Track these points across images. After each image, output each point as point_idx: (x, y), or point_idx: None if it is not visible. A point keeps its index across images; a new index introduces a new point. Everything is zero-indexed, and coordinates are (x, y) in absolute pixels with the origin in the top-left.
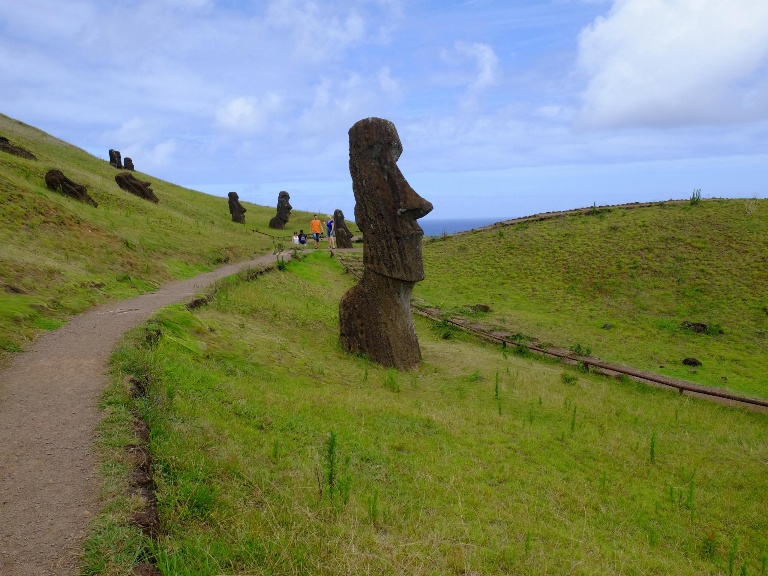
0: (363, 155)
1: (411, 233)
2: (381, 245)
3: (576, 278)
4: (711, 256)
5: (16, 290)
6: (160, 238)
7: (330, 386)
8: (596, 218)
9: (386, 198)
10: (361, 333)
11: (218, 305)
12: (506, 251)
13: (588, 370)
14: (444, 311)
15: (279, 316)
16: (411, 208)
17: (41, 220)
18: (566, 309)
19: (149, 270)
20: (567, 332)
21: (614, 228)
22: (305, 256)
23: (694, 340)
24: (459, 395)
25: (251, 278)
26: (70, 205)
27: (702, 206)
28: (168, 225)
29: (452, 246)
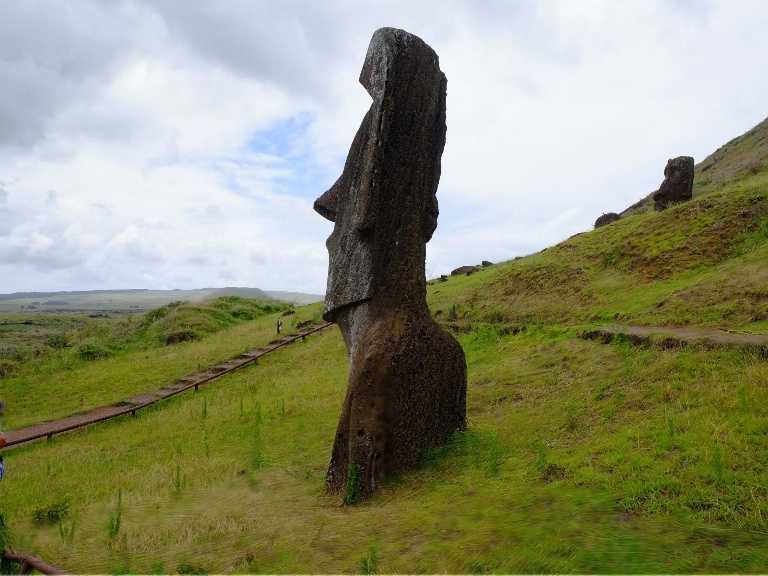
0: None
1: None
2: None
3: None
4: None
5: (660, 304)
6: None
7: None
8: None
9: None
10: None
11: None
12: None
13: None
14: None
15: None
16: None
17: None
18: None
19: None
20: None
21: None
22: None
23: None
24: None
25: None
26: None
27: None
28: None
29: None
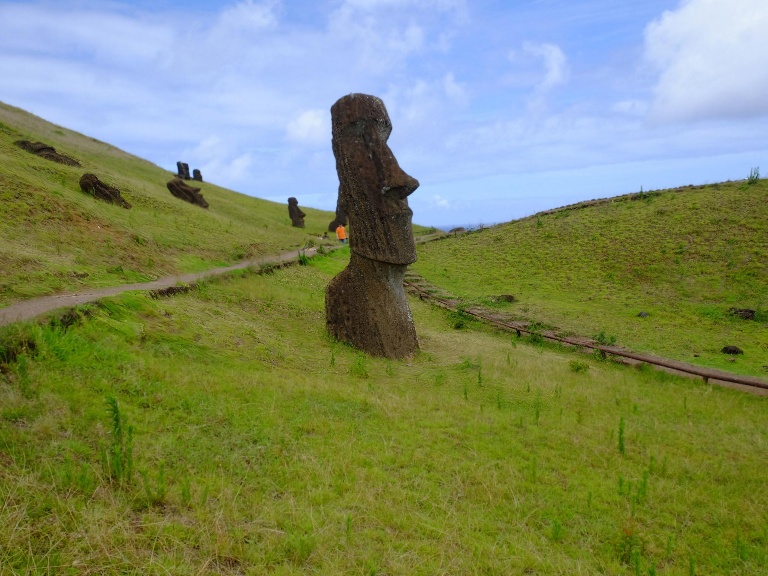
0: (345, 133)
1: (397, 213)
2: (365, 226)
3: (615, 265)
4: (767, 237)
5: None
6: (182, 236)
7: (284, 370)
8: (643, 203)
9: (370, 177)
10: (347, 320)
11: (199, 293)
12: (543, 240)
13: (605, 359)
14: (465, 302)
15: (272, 306)
16: (395, 186)
17: (46, 216)
18: (600, 298)
19: (151, 263)
20: (595, 321)
21: (661, 212)
22: (332, 251)
23: (740, 327)
24: (435, 382)
25: (265, 272)
26: (92, 205)
27: (761, 185)
28: (196, 224)
29: (488, 237)
